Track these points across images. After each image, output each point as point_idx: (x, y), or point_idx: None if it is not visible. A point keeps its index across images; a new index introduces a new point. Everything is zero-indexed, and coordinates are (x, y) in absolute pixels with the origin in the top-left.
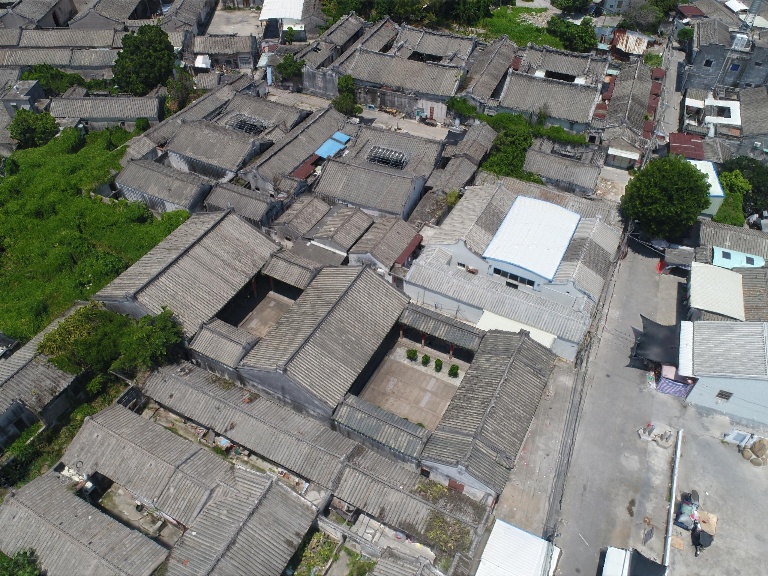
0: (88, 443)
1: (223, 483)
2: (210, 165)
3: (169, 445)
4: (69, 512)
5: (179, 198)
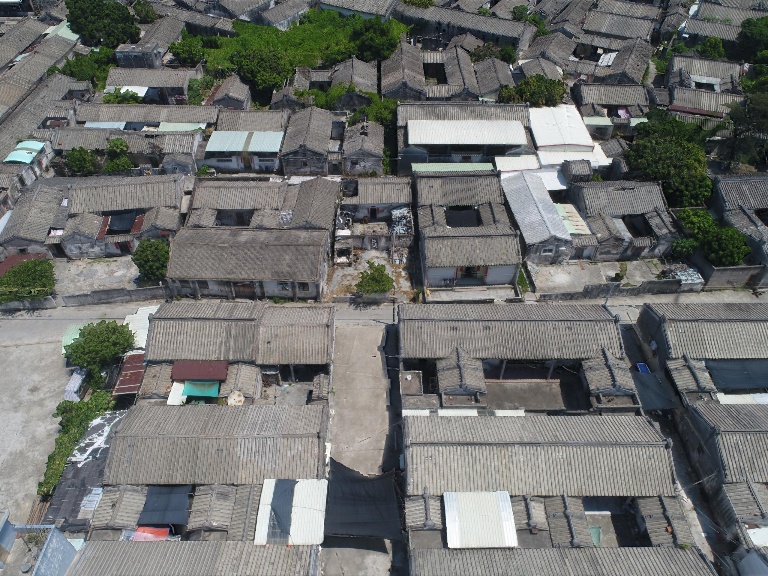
0: (467, 8)
1: None
2: (262, 5)
3: None
4: (496, 7)
5: (301, 5)
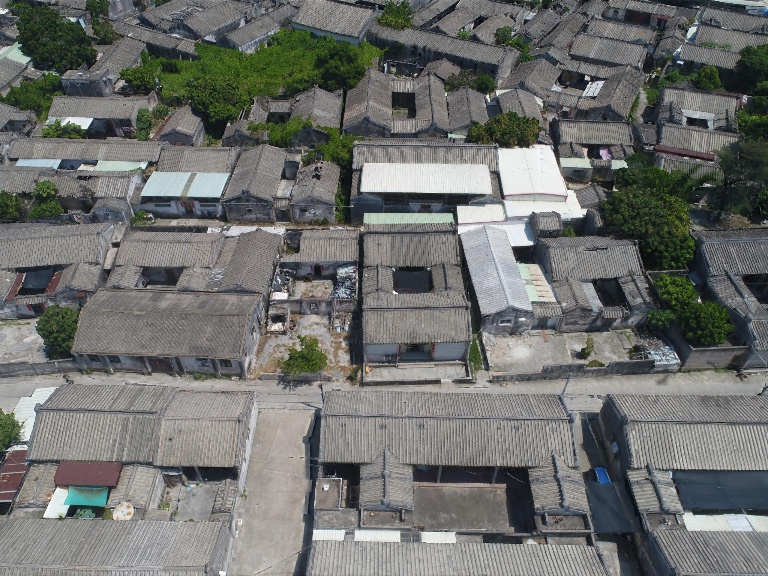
0: (448, 29)
1: (465, 5)
2: (231, 24)
3: (447, 17)
4: None
5: (271, 25)
